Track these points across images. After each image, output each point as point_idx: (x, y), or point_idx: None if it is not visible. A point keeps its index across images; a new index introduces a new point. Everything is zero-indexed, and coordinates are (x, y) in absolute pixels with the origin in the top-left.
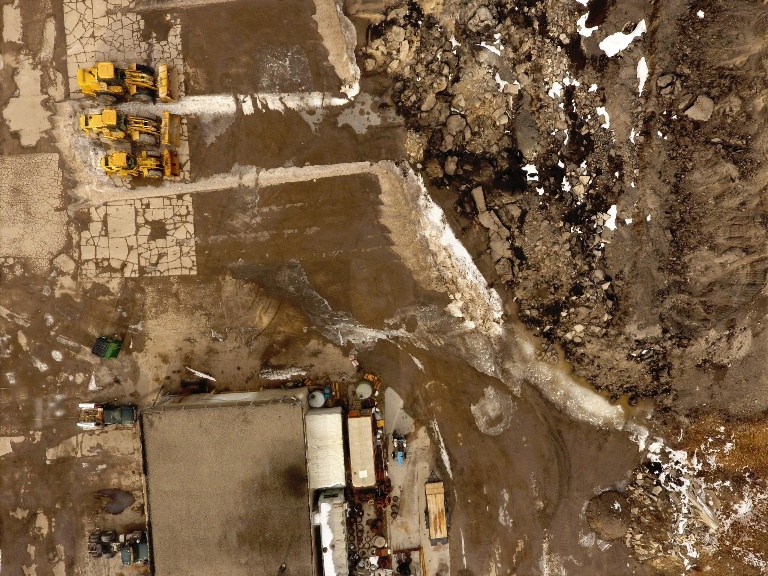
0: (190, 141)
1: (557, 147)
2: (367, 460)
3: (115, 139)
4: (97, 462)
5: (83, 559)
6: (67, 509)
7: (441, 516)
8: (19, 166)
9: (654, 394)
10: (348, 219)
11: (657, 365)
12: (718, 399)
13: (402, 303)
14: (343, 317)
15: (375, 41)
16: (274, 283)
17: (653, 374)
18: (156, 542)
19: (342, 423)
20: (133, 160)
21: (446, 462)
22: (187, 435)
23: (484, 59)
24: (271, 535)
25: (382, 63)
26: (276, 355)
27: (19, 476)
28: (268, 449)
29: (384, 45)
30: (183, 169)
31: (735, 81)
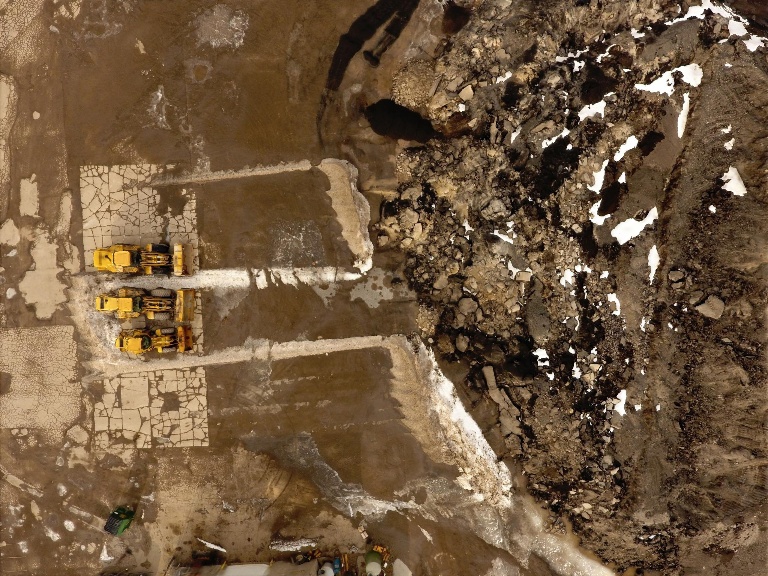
0: (204, 314)
1: (568, 336)
2: None
3: (130, 317)
4: None
5: None
6: None
7: None
8: (34, 338)
9: (660, 568)
10: (359, 392)
11: (664, 548)
12: (724, 575)
13: (412, 475)
14: (353, 489)
15: (388, 218)
16: (285, 455)
17: (660, 554)
18: None
19: None
20: (148, 341)
21: None
22: None
23: (497, 250)
24: None
25: (395, 238)
26: (286, 526)
27: None
28: None
29: (397, 224)
30: (196, 342)
31: (746, 287)
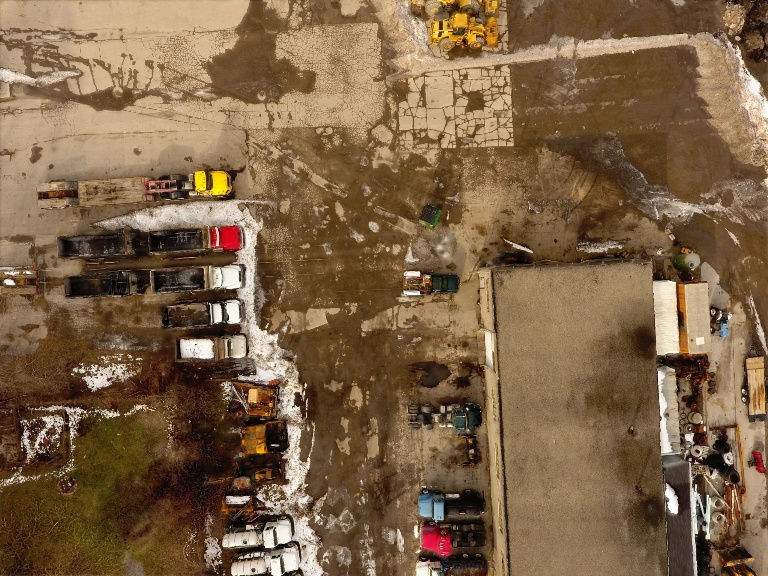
0: (508, 12)
1: None
2: (704, 327)
3: (443, 6)
4: (412, 334)
5: (397, 433)
6: (381, 382)
7: (760, 392)
8: (339, 35)
9: None
10: (665, 92)
11: None
12: None
13: (718, 177)
14: (659, 191)
15: None
16: (590, 156)
17: None
18: (505, 402)
19: (676, 290)
20: (467, 24)
21: (762, 339)
22: (537, 294)
23: None
24: (619, 397)
25: None
26: (593, 228)
27: (334, 348)
28: (617, 309)
29: None
30: (501, 40)
31: None
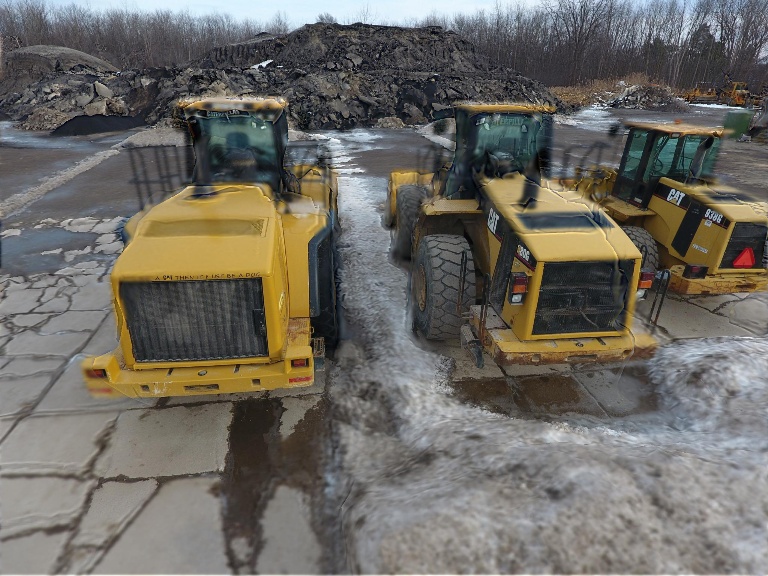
0: None
1: None
2: None
3: None
4: None
5: None
6: None
7: None
8: None
9: None
10: None
11: None
12: None
13: None
14: None
15: None
16: None
17: None
18: None
19: None
20: None
21: None
22: None
23: None
24: None
25: None
26: None
27: None
28: None
29: None
30: None
31: (338, 47)
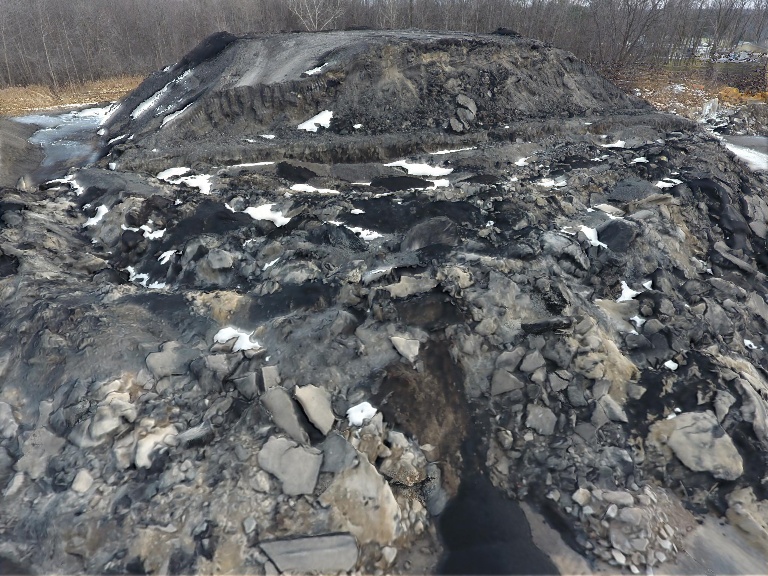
0: None
1: None
2: None
3: None
4: None
5: None
6: None
7: None
8: None
9: None
10: None
11: None
12: None
13: None
14: None
15: None
16: None
17: None
18: None
19: None
20: None
21: None
22: None
23: None
24: None
25: None
26: None
27: None
28: None
29: None
30: None
31: (434, 84)
